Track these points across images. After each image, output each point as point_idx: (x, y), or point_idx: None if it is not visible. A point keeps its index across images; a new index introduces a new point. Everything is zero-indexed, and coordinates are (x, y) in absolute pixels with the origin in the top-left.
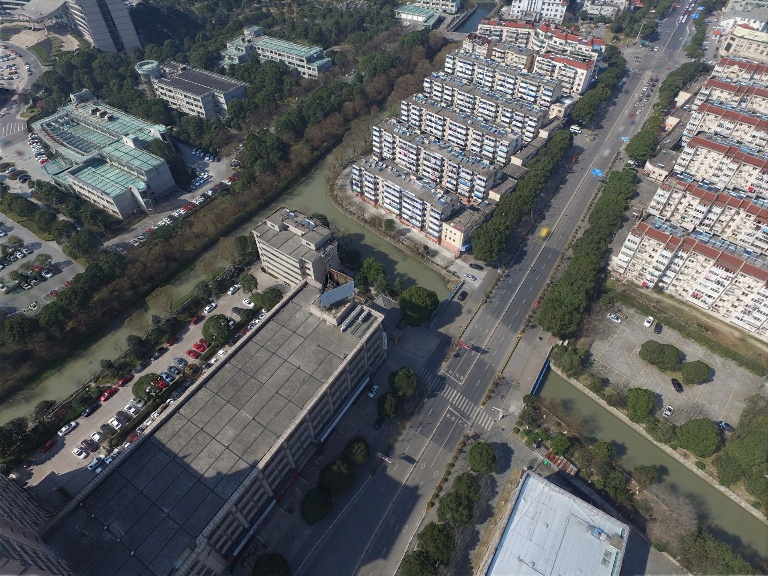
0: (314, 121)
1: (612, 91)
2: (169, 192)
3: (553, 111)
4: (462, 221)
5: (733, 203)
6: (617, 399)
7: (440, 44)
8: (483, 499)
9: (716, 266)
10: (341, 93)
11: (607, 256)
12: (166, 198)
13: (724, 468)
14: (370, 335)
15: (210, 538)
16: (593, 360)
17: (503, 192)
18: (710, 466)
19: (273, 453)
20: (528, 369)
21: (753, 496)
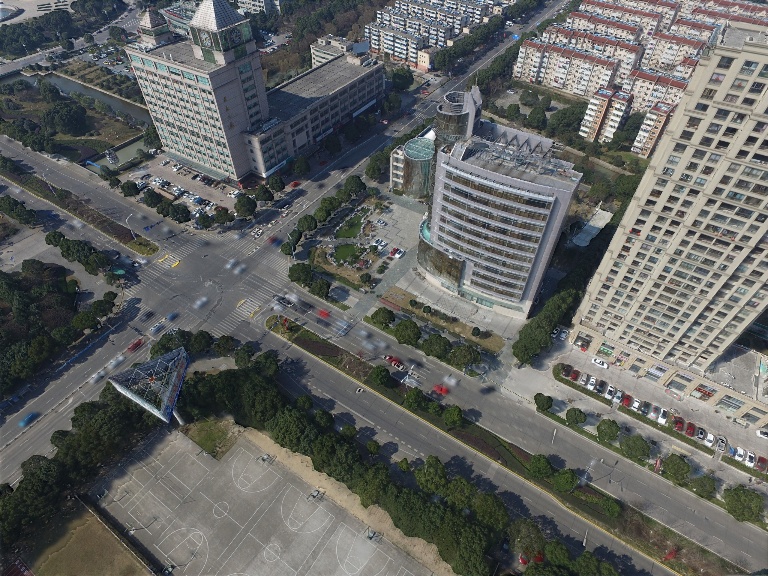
0: (339, 13)
1: (540, 7)
2: None
3: (495, 11)
4: (429, 50)
5: (581, 35)
6: (501, 109)
7: None
8: None
9: (562, 57)
10: (355, 2)
11: (510, 65)
12: None
13: (547, 128)
14: (377, 69)
15: (310, 114)
16: (495, 104)
17: (455, 40)
18: (543, 133)
19: (335, 91)
20: None
21: (560, 140)
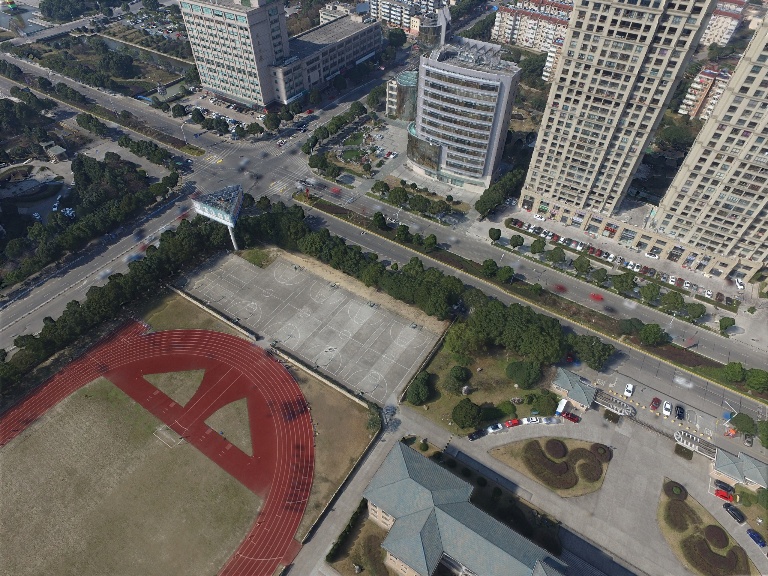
0: None
1: None
2: None
3: None
4: None
5: (549, 3)
6: None
7: None
8: None
9: (531, 19)
10: None
11: (489, 29)
12: None
13: None
14: (376, 25)
15: None
16: None
17: None
18: None
19: None
20: None
21: (526, 83)
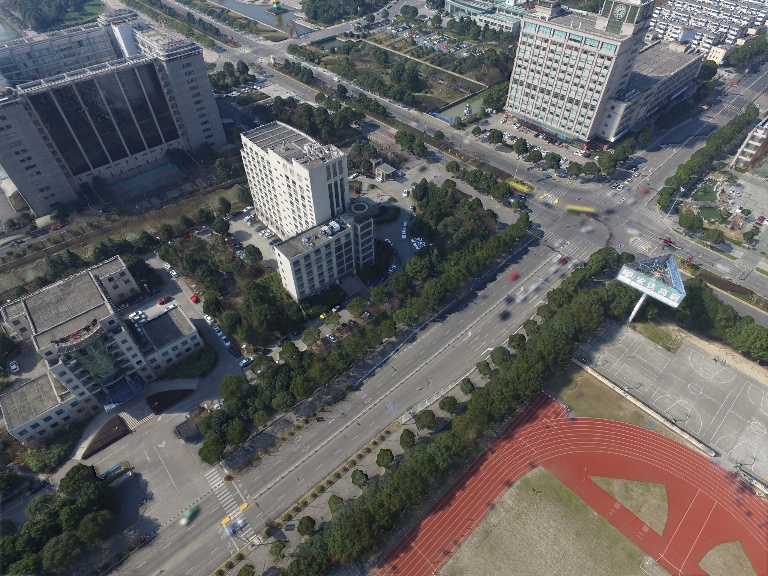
0: None
1: None
2: None
3: None
4: None
5: None
6: None
7: None
8: (750, 129)
9: None
10: None
11: None
12: None
13: None
14: (700, 57)
15: None
16: None
17: (747, 39)
18: None
19: None
20: (767, 102)
21: None
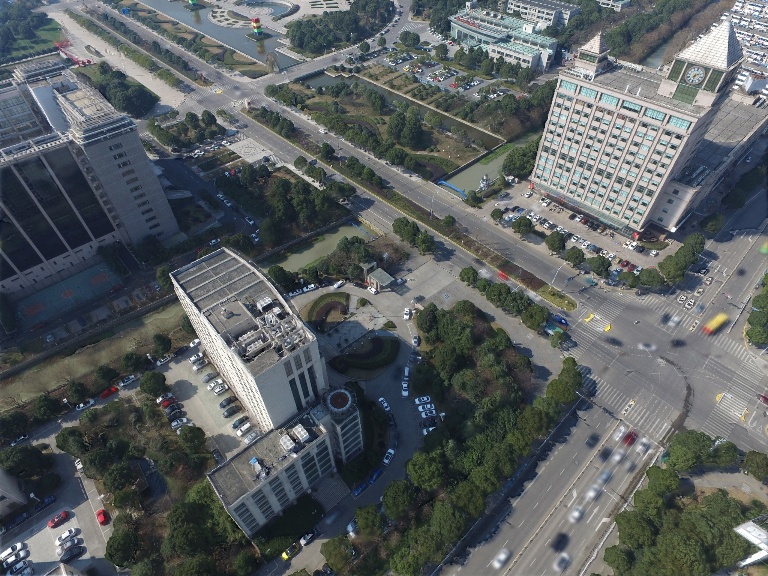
0: (644, 32)
1: None
2: (551, 64)
3: None
4: None
5: None
6: None
7: (709, 0)
8: None
9: None
10: None
11: None
12: (549, 67)
13: None
14: None
15: None
16: None
17: None
18: None
19: None
20: None
21: None
